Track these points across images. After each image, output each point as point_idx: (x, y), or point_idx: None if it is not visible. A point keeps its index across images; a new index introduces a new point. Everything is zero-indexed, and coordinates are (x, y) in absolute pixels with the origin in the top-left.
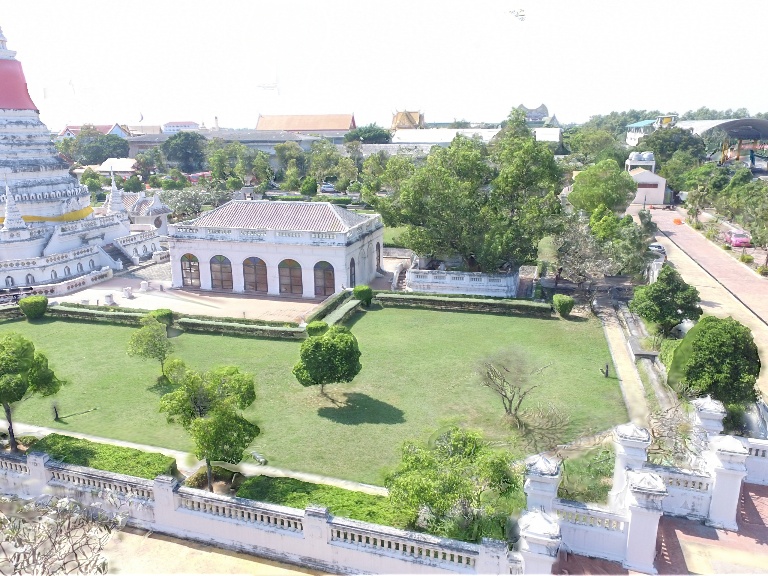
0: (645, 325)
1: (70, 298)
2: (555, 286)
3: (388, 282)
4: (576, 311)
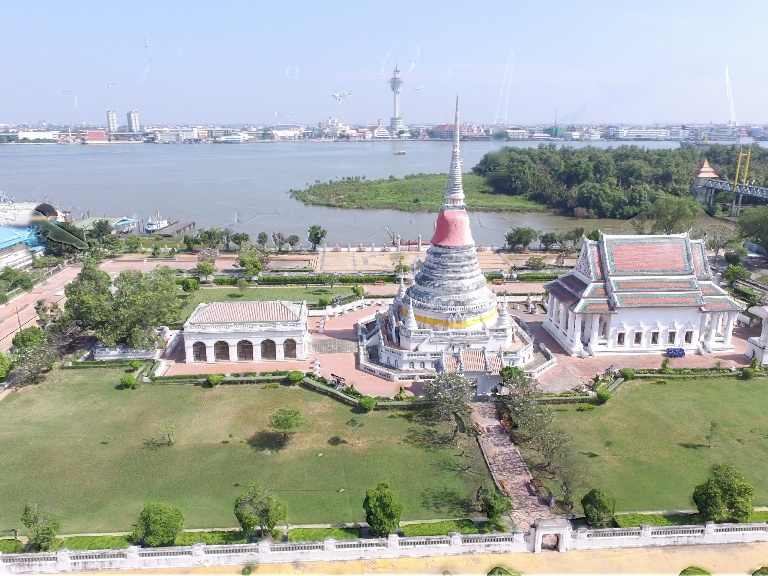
0: (73, 322)
1: (349, 323)
2: (85, 343)
3: (182, 348)
4: (89, 333)
